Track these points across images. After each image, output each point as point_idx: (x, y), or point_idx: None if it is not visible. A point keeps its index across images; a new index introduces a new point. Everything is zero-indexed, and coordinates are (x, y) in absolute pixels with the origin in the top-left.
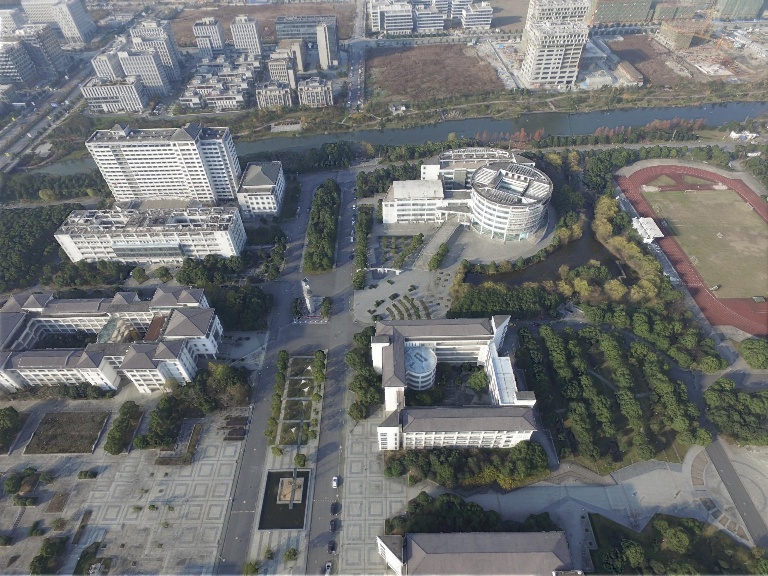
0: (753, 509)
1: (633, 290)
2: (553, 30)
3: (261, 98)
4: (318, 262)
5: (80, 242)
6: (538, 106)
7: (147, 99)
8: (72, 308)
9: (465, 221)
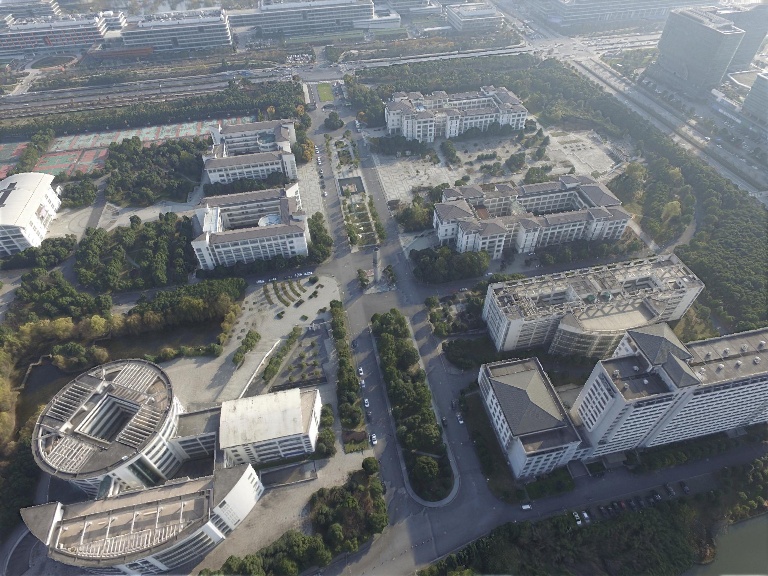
0: None
1: (47, 321)
2: None
3: None
4: None
5: None
6: None
7: None
8: (565, 213)
9: None
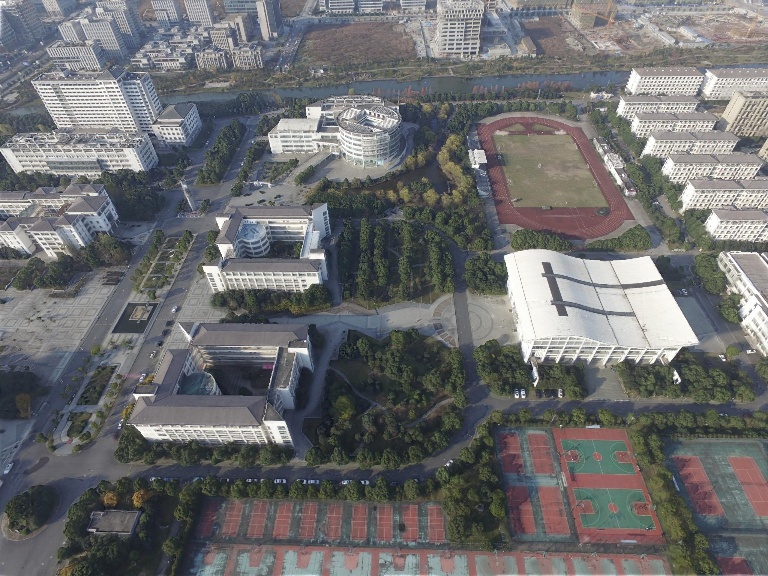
0: (469, 330)
1: (443, 197)
2: (453, 5)
3: (200, 60)
4: (207, 176)
5: (20, 156)
6: (439, 71)
7: (105, 61)
8: (3, 196)
9: (335, 151)
